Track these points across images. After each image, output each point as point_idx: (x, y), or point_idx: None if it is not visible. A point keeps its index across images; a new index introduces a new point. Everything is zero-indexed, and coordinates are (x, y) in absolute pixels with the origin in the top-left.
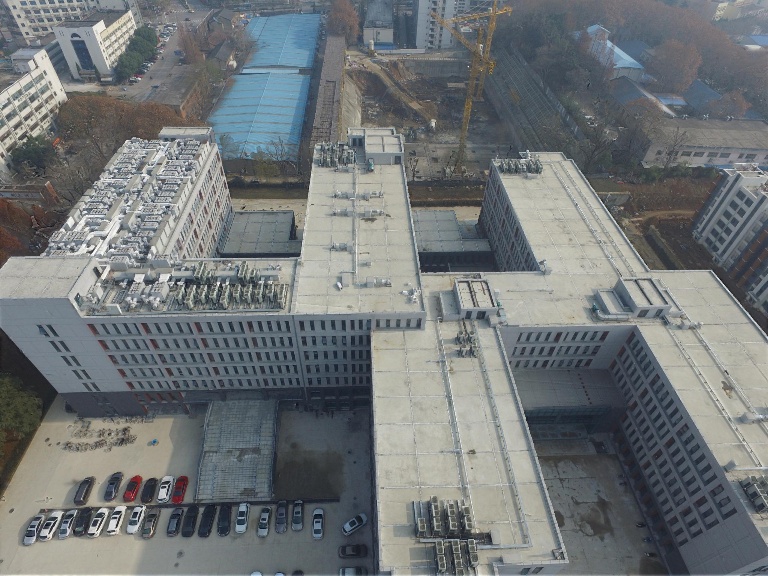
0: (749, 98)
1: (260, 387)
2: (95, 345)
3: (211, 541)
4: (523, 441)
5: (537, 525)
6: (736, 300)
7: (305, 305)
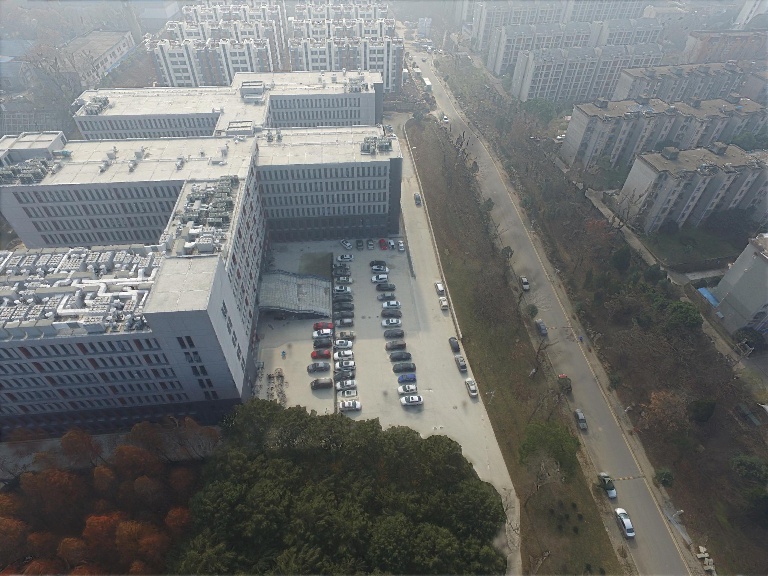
0: (30, 37)
1: (259, 268)
2: (233, 302)
3: (356, 304)
4: (332, 129)
5: (369, 130)
6: (259, 72)
7: (238, 175)
